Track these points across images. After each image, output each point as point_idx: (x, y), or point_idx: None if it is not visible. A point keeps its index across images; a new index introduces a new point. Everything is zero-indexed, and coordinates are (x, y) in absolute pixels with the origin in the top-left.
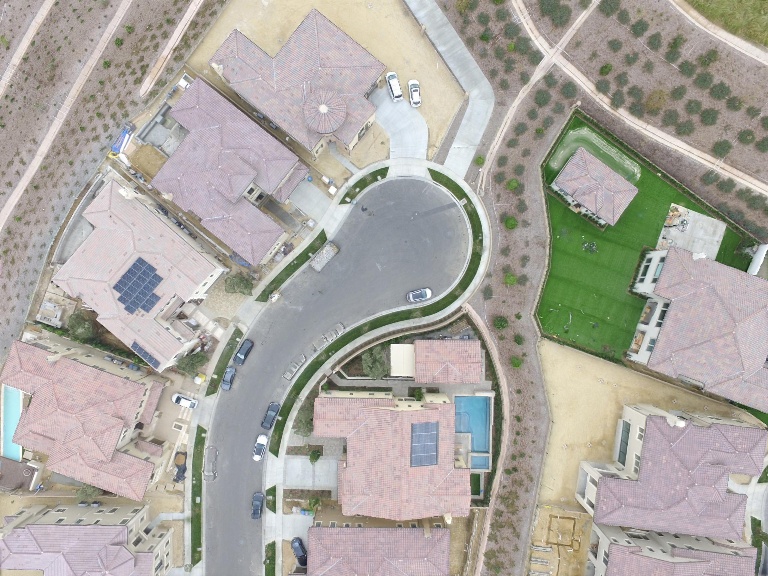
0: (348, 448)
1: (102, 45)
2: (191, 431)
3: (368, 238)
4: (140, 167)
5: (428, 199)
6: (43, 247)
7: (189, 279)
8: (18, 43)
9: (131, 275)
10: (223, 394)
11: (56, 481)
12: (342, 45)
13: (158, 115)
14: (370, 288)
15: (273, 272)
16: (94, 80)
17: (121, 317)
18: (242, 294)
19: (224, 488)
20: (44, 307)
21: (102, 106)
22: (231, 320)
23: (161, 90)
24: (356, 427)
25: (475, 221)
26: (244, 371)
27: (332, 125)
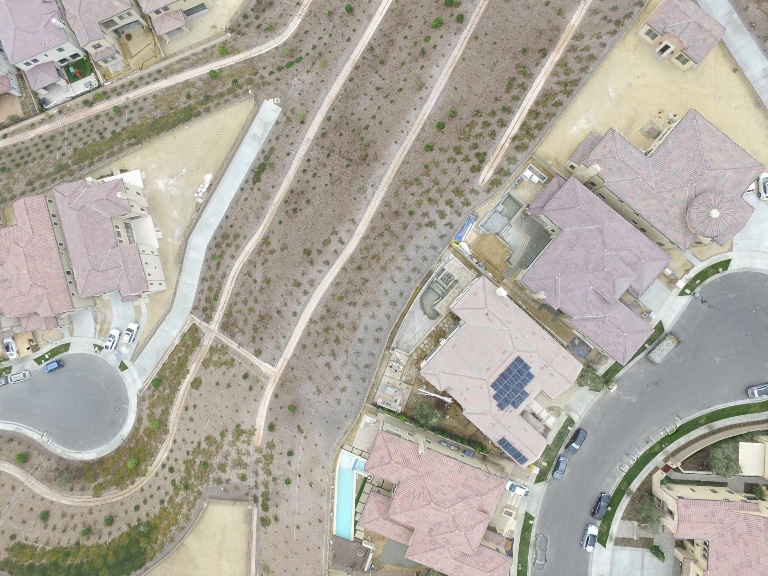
0: (710, 551)
1: (416, 126)
2: (519, 517)
3: (707, 331)
4: (481, 255)
5: None
6: (379, 331)
7: (563, 378)
8: (313, 118)
9: (508, 373)
10: (552, 482)
11: (386, 561)
12: (722, 146)
13: (500, 204)
14: (707, 381)
15: (608, 362)
16: (413, 162)
17: (492, 413)
18: (576, 383)
19: (549, 575)
20: (381, 390)
21: (431, 191)
22: (563, 409)
23: None
24: (721, 531)
25: None
26: (574, 460)
27: (720, 229)
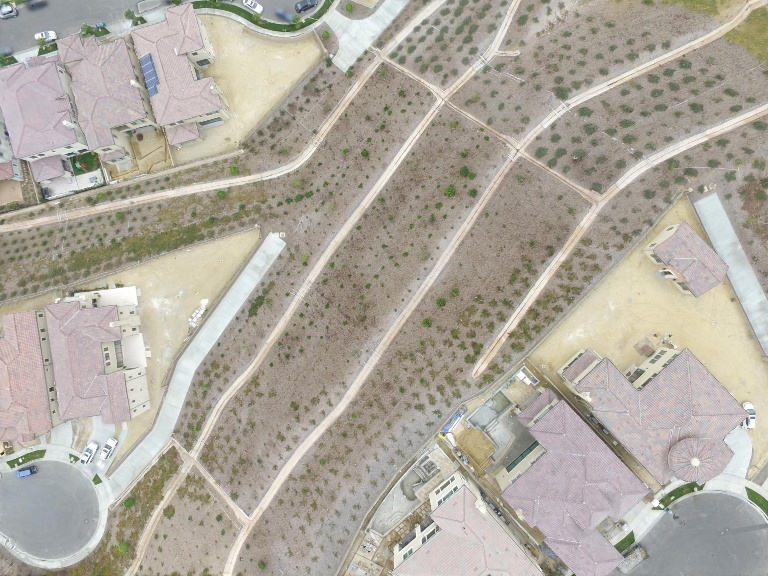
0: None
1: (417, 295)
2: None
3: (676, 546)
4: (466, 449)
5: (741, 517)
6: (357, 508)
7: None
8: (316, 261)
9: None
10: None
11: None
12: (711, 390)
13: (490, 400)
14: None
15: None
16: (410, 334)
17: None
18: None
19: None
20: (352, 568)
21: (425, 371)
22: None
23: (499, 379)
24: None
25: None
26: None
27: (698, 476)
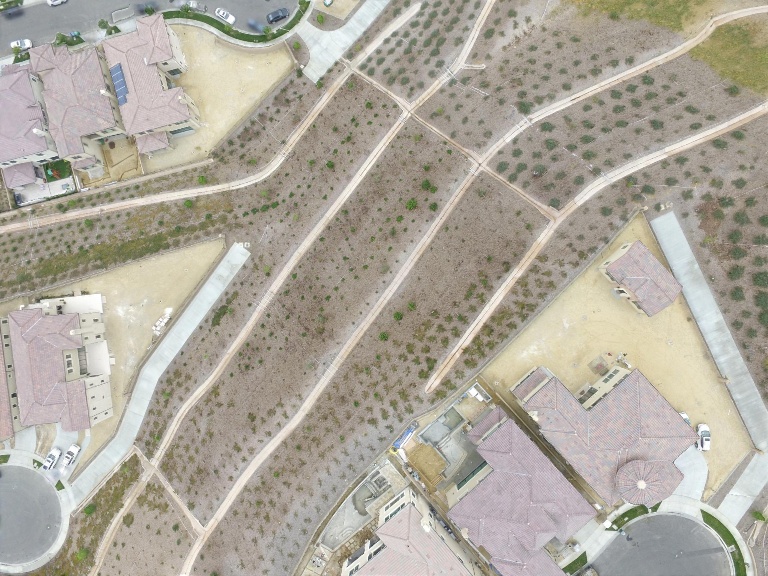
0: None
1: (376, 308)
2: None
3: (629, 568)
4: (417, 465)
5: (696, 540)
6: (308, 522)
7: None
8: (279, 272)
9: None
10: None
11: None
12: (661, 411)
13: (442, 416)
14: None
15: None
16: (367, 347)
17: None
18: None
19: None
20: None
21: (379, 385)
22: None
23: (451, 396)
24: None
25: (741, 570)
26: None
27: (645, 499)
